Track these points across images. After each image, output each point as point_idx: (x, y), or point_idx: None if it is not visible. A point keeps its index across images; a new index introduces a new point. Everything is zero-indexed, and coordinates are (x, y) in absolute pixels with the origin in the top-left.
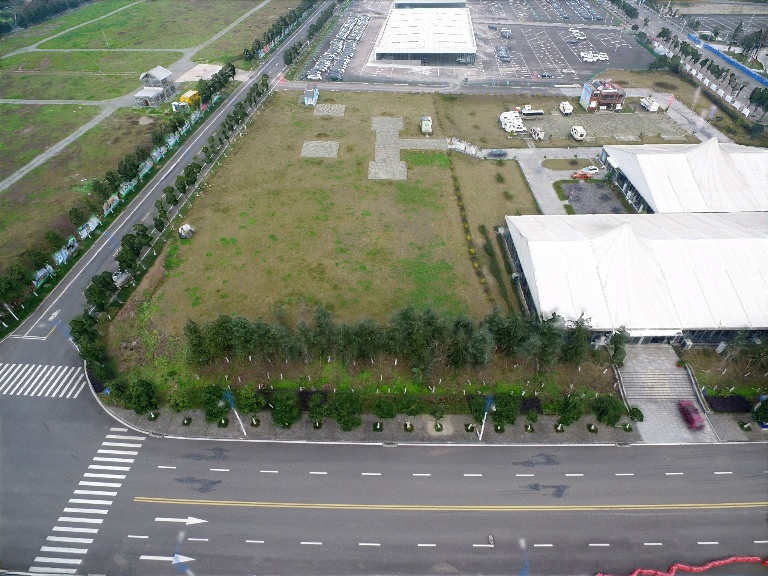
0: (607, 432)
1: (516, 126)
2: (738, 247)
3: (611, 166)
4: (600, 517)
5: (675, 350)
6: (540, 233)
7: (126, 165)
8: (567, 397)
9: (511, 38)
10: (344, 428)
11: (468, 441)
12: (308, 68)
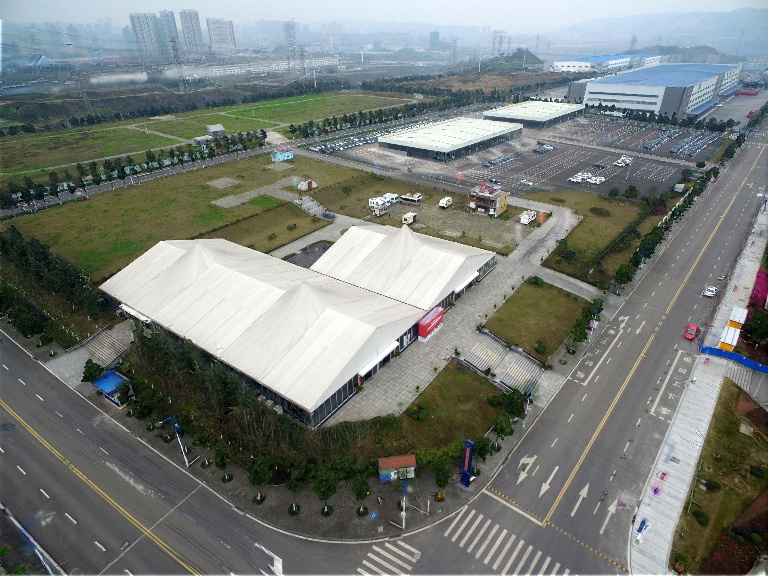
0: (42, 350)
1: (375, 203)
2: (255, 287)
3: None
4: None
5: None
6: (187, 243)
7: (111, 163)
8: (62, 328)
9: (541, 153)
10: None
11: None
12: None
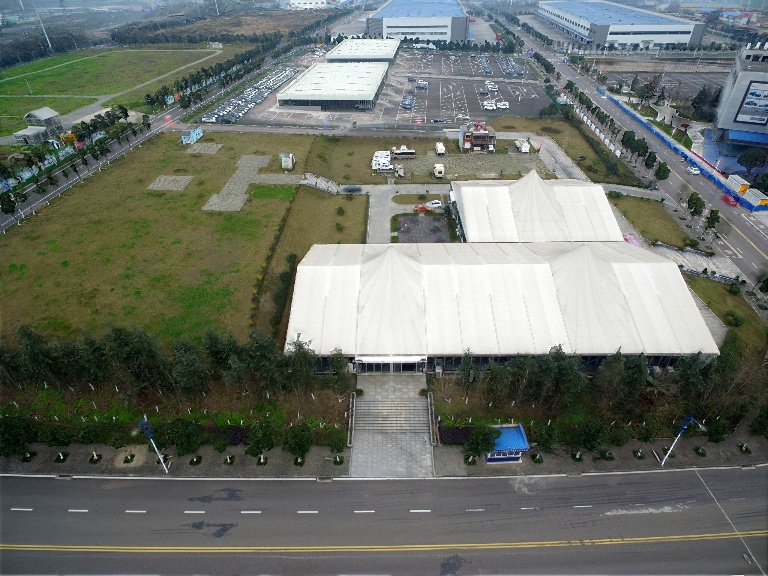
0: (314, 465)
1: (381, 164)
2: (509, 272)
3: None
4: (252, 560)
5: (427, 378)
6: (322, 259)
7: None
8: None
9: (425, 89)
10: (23, 459)
11: (153, 474)
12: (209, 112)
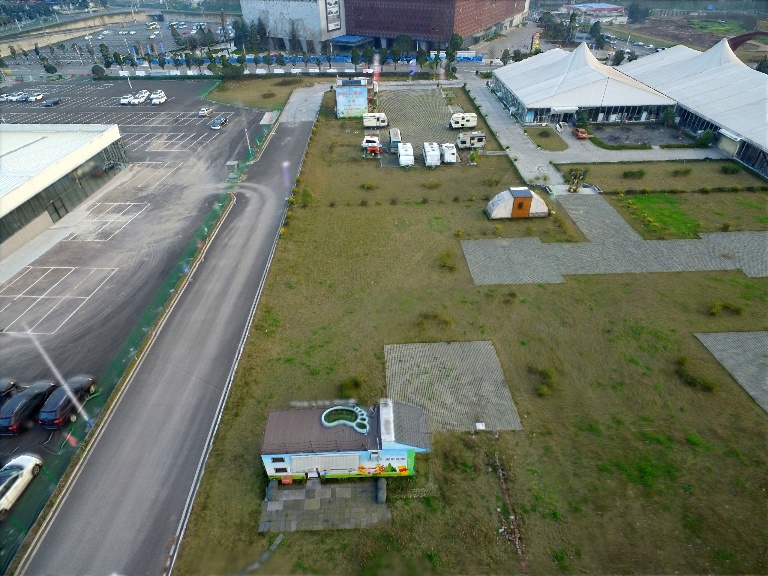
0: None
1: None
2: None
3: (561, 114)
4: None
5: None
6: None
7: None
8: None
9: None
10: None
11: None
12: None
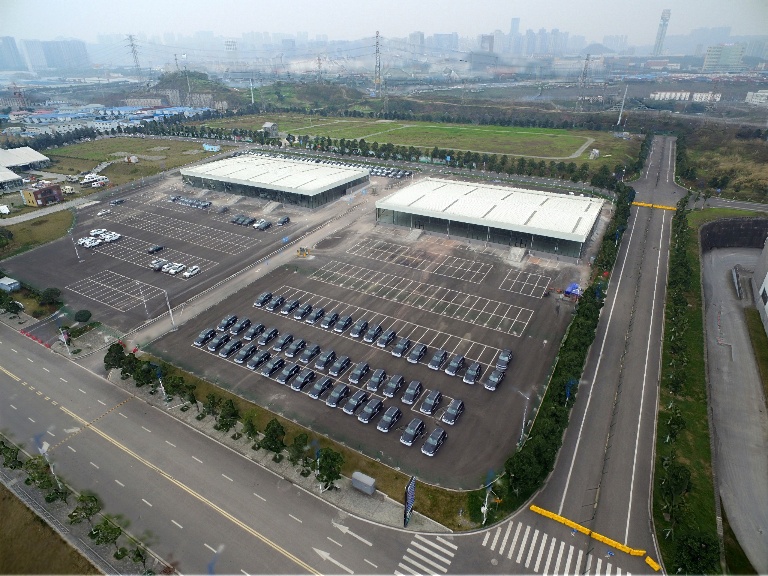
0: None
1: None
2: None
3: None
4: None
5: None
6: (26, 150)
7: None
8: None
9: None
10: None
11: None
12: None
